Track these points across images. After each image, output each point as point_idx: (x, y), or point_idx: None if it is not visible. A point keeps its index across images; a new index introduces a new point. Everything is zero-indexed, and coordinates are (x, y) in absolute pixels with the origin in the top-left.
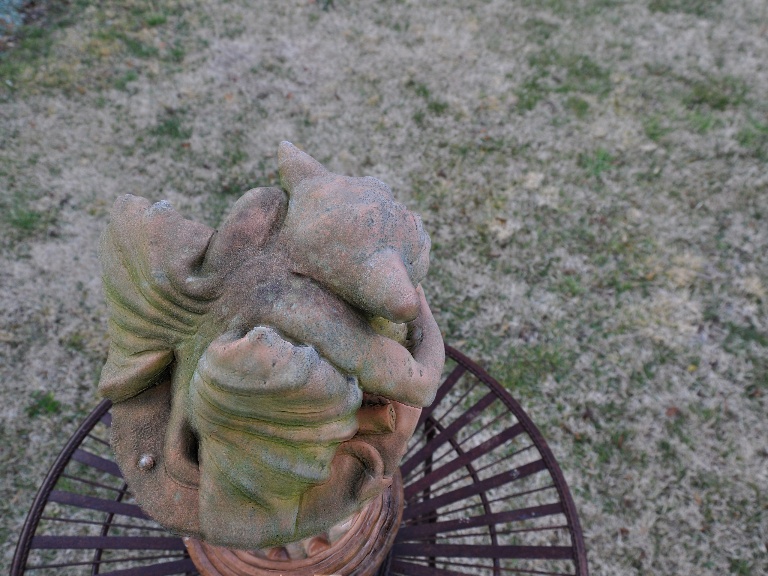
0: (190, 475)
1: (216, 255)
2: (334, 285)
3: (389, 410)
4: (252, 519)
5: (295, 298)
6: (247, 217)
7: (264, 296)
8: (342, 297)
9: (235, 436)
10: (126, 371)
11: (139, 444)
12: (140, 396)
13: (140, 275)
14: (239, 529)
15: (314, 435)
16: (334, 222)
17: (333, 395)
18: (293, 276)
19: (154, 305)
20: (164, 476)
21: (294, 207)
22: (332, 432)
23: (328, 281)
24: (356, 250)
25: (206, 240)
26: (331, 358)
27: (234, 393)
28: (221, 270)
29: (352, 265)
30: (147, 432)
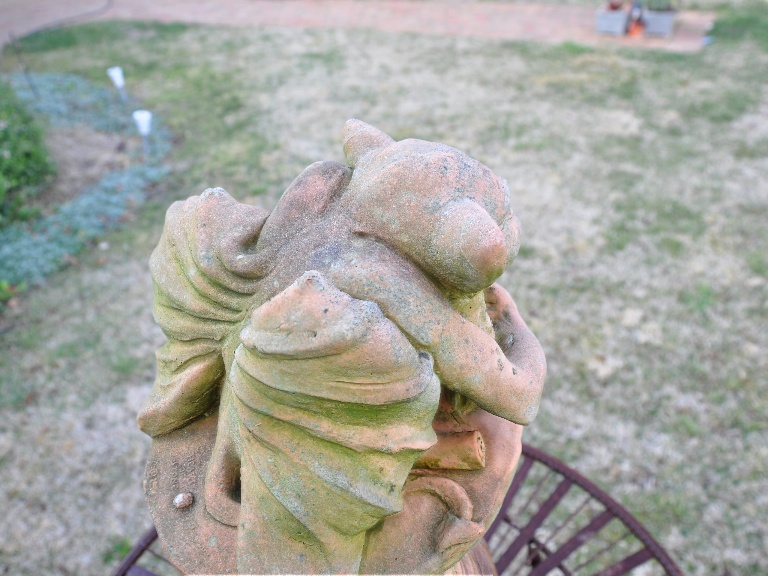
0: (232, 509)
1: (271, 229)
2: (402, 241)
3: (476, 436)
4: (302, 560)
5: (356, 254)
6: (306, 185)
7: (321, 259)
8: (412, 257)
9: (282, 433)
10: (172, 391)
11: (179, 478)
12: (187, 428)
13: (190, 262)
14: (285, 571)
15: (379, 434)
16: (401, 171)
17: (400, 358)
18: (355, 236)
19: (202, 293)
20: (203, 513)
21: (358, 173)
22: (402, 434)
23: (395, 237)
24: (427, 199)
25: (262, 219)
26: (398, 320)
27: (279, 355)
28: (276, 242)
29: (423, 216)
30: (189, 465)
